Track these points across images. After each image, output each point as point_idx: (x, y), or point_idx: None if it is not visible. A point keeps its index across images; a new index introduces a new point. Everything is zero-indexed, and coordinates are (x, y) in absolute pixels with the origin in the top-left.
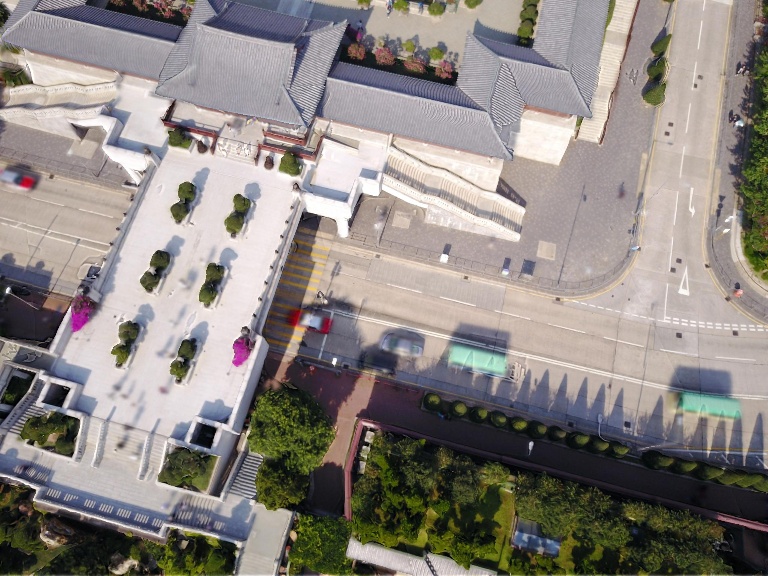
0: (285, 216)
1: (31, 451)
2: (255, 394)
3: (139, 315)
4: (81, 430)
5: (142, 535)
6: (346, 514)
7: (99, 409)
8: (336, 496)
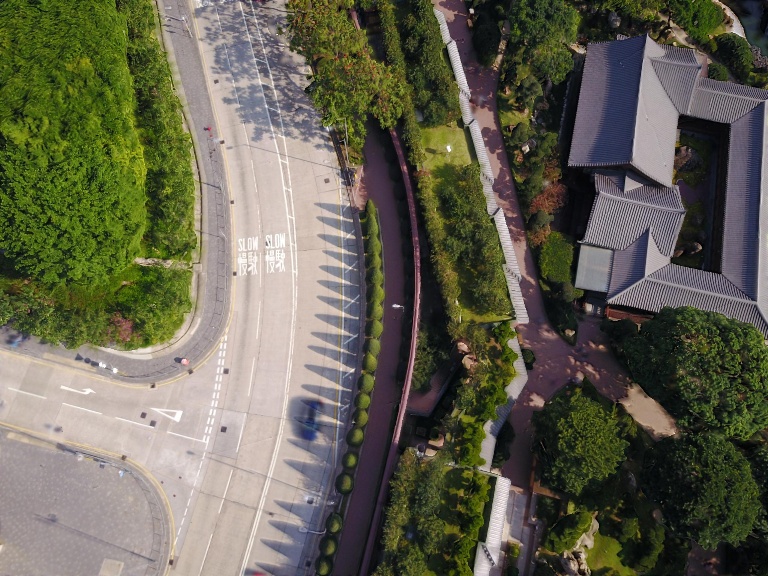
0: None
1: None
2: None
3: None
4: None
5: None
6: None
7: None
8: None
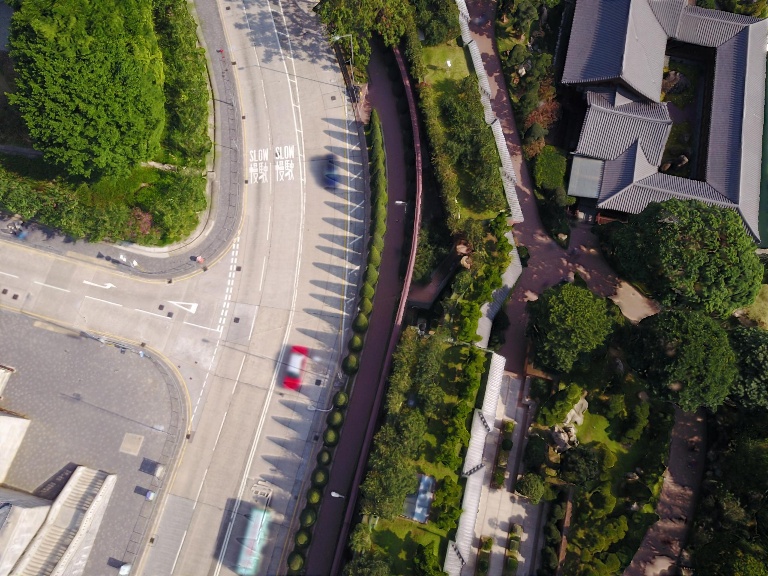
0: None
1: None
2: None
3: None
4: None
5: None
6: None
7: None
8: None
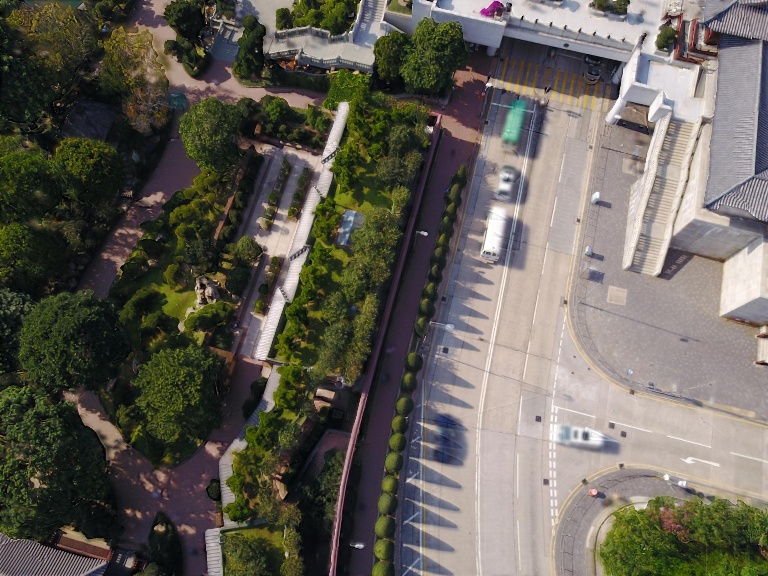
0: None
1: None
2: None
3: None
4: None
5: None
6: None
7: None
8: None
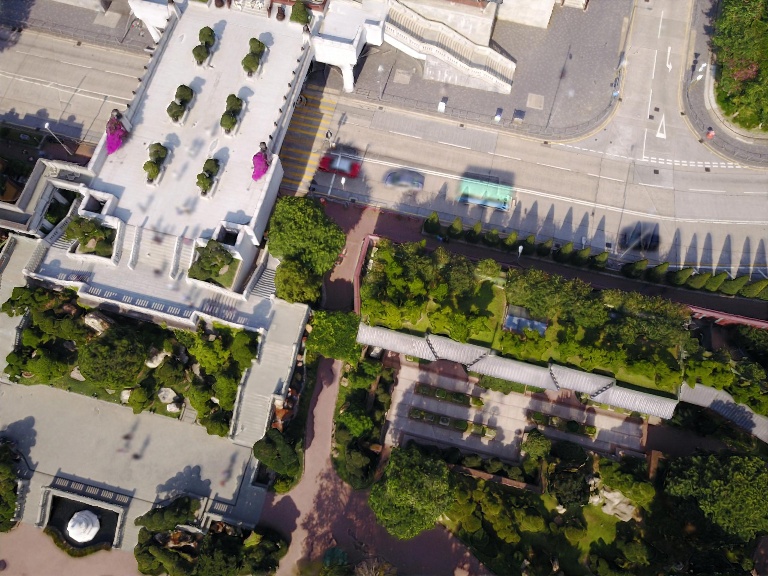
0: (296, 60)
1: (72, 261)
2: (272, 211)
3: (166, 142)
4: (118, 234)
5: (175, 324)
6: (356, 310)
7: (133, 219)
8: (346, 304)
